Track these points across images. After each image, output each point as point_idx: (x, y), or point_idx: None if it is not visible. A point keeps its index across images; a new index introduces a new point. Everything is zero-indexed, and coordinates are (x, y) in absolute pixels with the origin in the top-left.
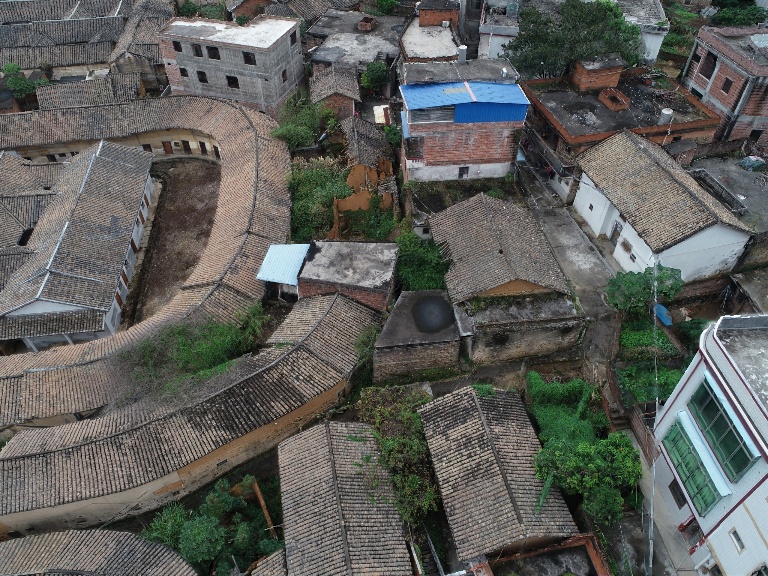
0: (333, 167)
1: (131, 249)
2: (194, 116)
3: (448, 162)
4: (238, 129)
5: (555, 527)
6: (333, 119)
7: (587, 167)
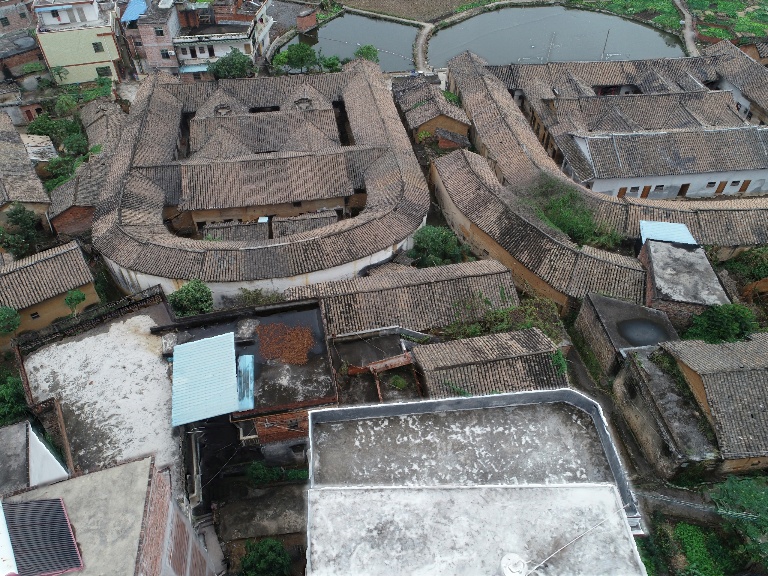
0: None
1: (679, 188)
2: None
3: None
4: None
5: None
6: None
7: None
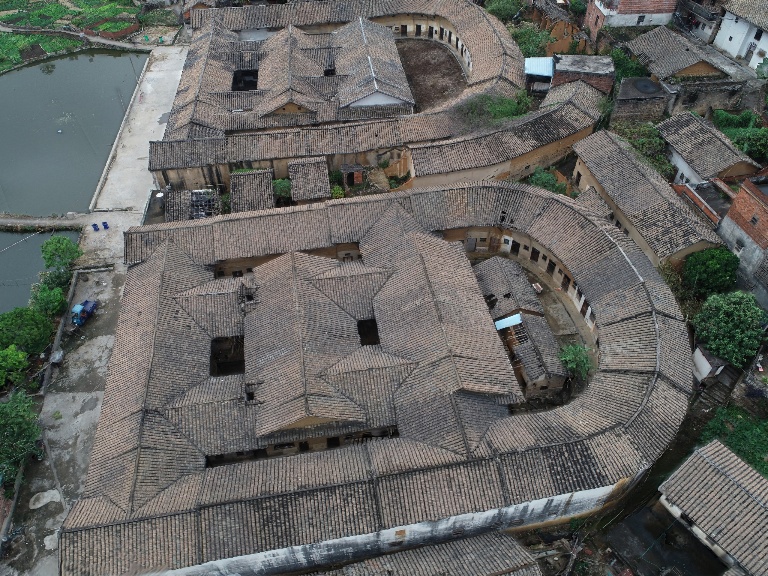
0: (534, 30)
1: None
2: (417, 4)
3: (632, 11)
4: (459, 8)
5: (754, 163)
6: (525, 2)
7: (731, 8)
